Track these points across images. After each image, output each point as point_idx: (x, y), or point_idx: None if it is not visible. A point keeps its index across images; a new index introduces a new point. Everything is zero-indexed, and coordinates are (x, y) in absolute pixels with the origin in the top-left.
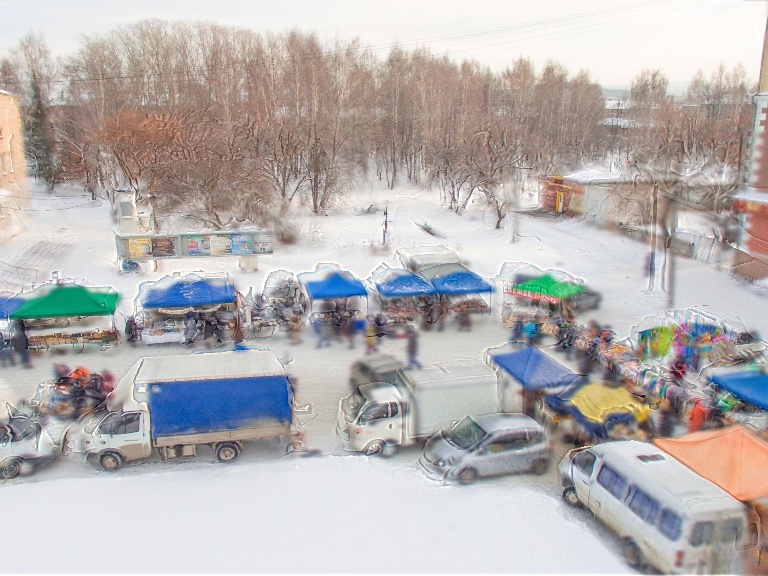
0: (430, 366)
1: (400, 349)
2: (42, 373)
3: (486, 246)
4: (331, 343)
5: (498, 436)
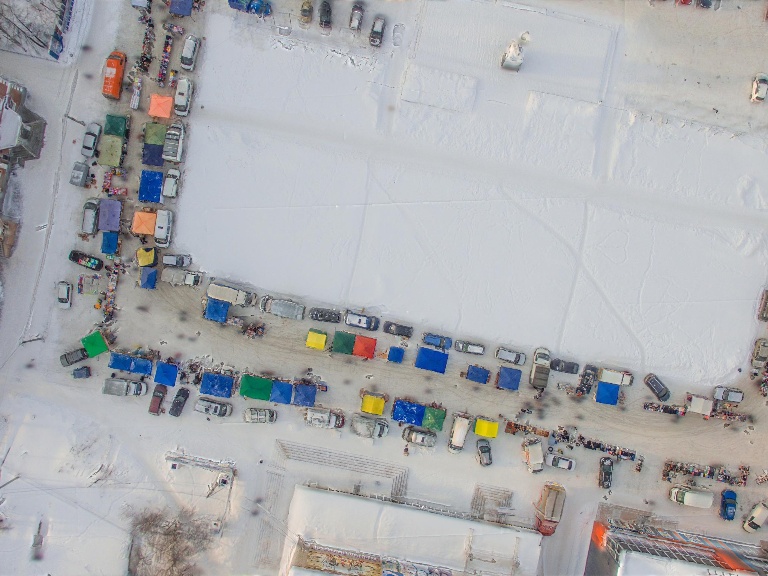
0: (175, 281)
1: (163, 328)
2: (264, 354)
3: (39, 463)
4: (181, 342)
5: (175, 255)
